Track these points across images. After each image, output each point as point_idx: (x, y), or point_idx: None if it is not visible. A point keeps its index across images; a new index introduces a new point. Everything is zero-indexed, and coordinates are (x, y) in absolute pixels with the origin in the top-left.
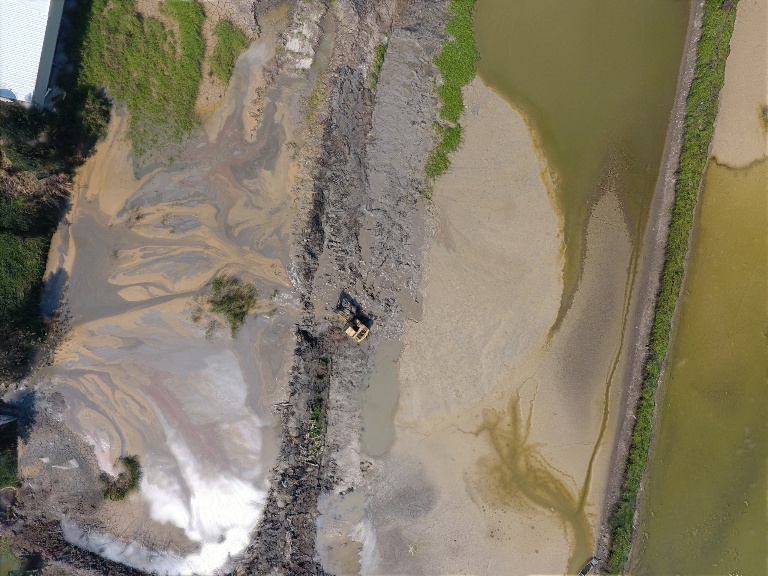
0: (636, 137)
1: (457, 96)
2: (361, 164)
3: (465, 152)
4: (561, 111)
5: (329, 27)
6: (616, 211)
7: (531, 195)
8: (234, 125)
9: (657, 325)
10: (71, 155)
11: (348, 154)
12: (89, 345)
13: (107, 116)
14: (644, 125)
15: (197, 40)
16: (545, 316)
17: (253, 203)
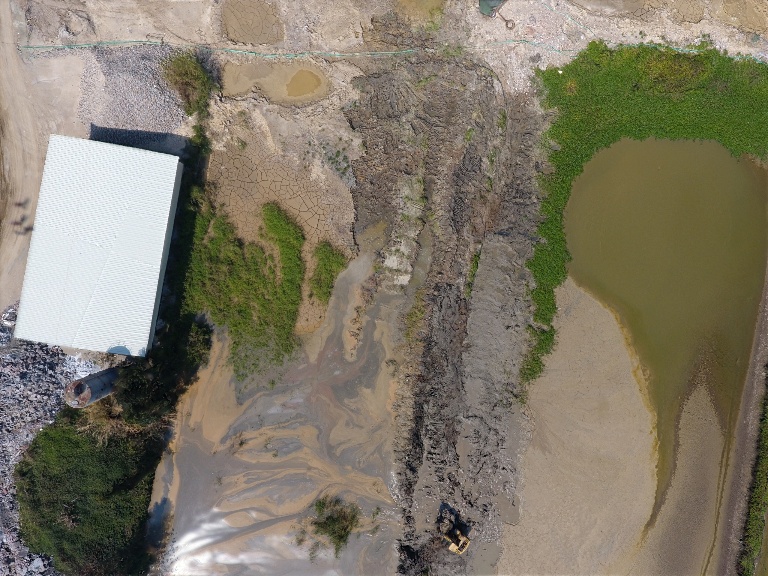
0: (726, 331)
1: (550, 299)
2: (458, 373)
3: (559, 354)
4: (652, 308)
5: (426, 242)
6: (707, 405)
7: (624, 393)
8: (334, 345)
9: (752, 522)
10: (175, 385)
11: (446, 366)
12: (195, 574)
13: (209, 343)
14: (733, 318)
15: (298, 265)
16: (640, 513)
17: (354, 422)
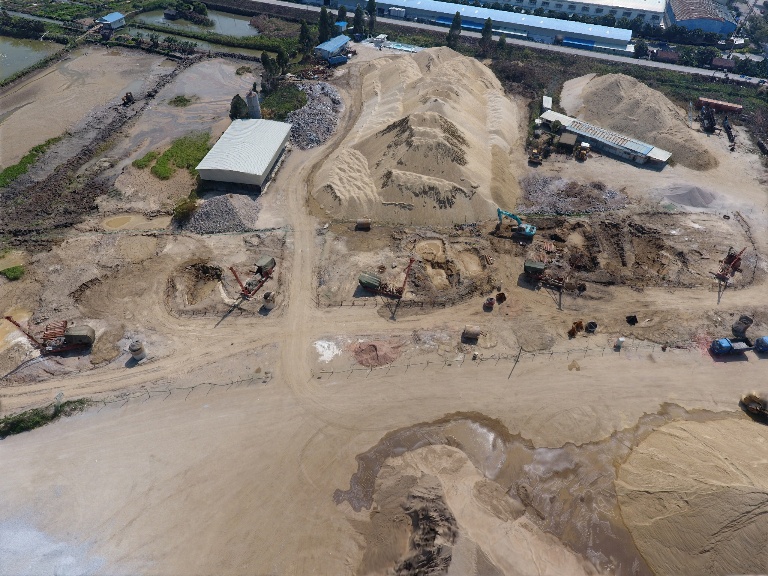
0: None
1: None
2: None
3: None
4: None
5: (81, 171)
6: None
7: None
8: None
9: None
10: None
11: None
12: None
13: None
14: None
15: None
16: None
17: None
